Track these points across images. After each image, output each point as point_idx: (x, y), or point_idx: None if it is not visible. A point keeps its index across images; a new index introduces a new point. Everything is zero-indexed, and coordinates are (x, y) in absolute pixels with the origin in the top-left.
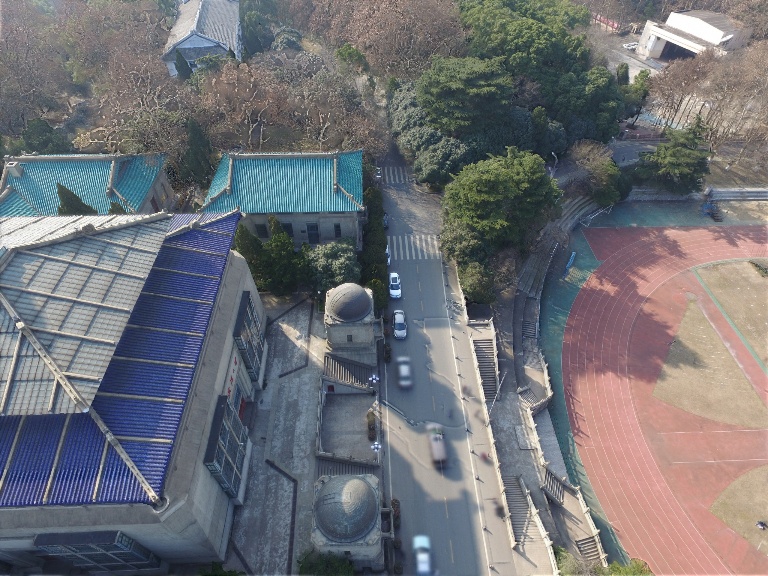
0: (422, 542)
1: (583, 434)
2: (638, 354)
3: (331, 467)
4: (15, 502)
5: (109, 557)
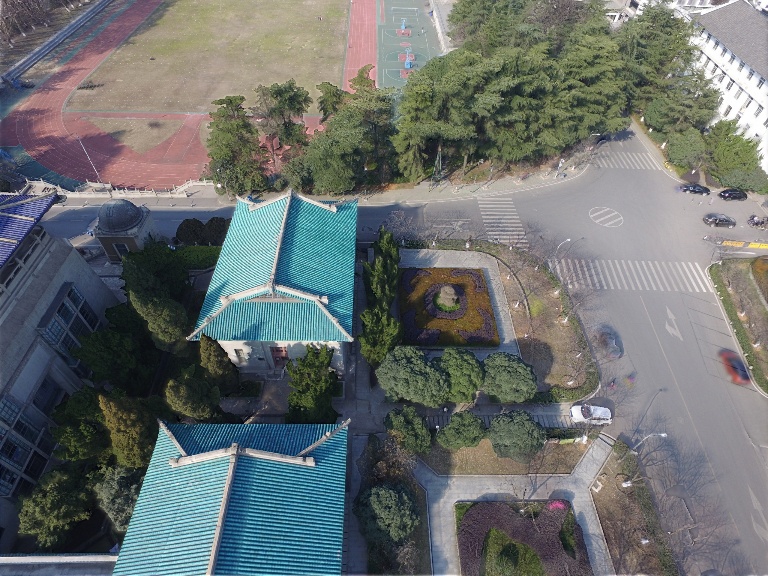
0: (166, 232)
1: (146, 186)
2: (109, 151)
3: (91, 262)
4: (6, 256)
5: (83, 326)
